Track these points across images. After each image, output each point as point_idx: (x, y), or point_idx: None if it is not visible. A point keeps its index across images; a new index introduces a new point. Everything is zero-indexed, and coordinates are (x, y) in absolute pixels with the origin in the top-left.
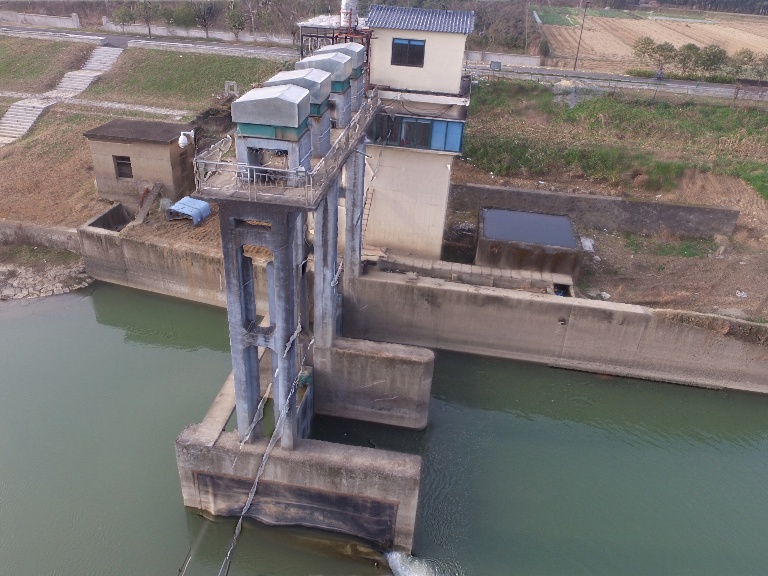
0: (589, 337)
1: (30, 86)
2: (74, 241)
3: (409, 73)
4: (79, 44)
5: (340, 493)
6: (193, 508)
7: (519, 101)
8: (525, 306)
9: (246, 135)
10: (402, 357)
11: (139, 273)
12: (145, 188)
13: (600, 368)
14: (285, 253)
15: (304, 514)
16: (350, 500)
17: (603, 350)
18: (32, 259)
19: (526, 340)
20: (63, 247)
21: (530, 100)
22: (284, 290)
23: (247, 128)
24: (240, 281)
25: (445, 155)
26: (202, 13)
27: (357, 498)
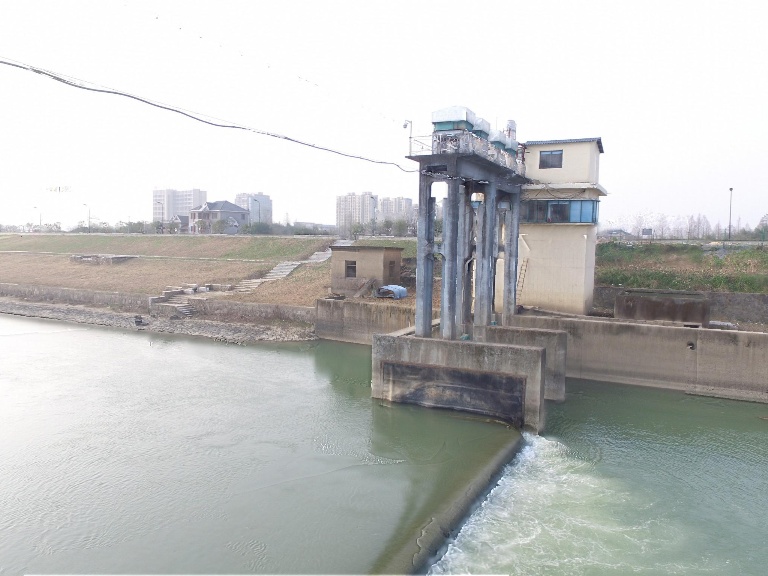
0: (719, 361)
1: (291, 258)
2: (310, 315)
3: (552, 172)
4: (326, 239)
5: (483, 371)
6: (377, 399)
7: (670, 256)
8: (655, 333)
9: (438, 130)
10: (540, 330)
11: (352, 329)
12: (363, 283)
13: (737, 394)
14: (454, 184)
15: (456, 396)
16: (490, 378)
17: (736, 374)
18: (282, 324)
19: (660, 367)
20: (302, 320)
21: (680, 255)
22: (452, 209)
23: (439, 126)
24: (427, 209)
25: (581, 226)
26: (413, 222)
27: (495, 375)
